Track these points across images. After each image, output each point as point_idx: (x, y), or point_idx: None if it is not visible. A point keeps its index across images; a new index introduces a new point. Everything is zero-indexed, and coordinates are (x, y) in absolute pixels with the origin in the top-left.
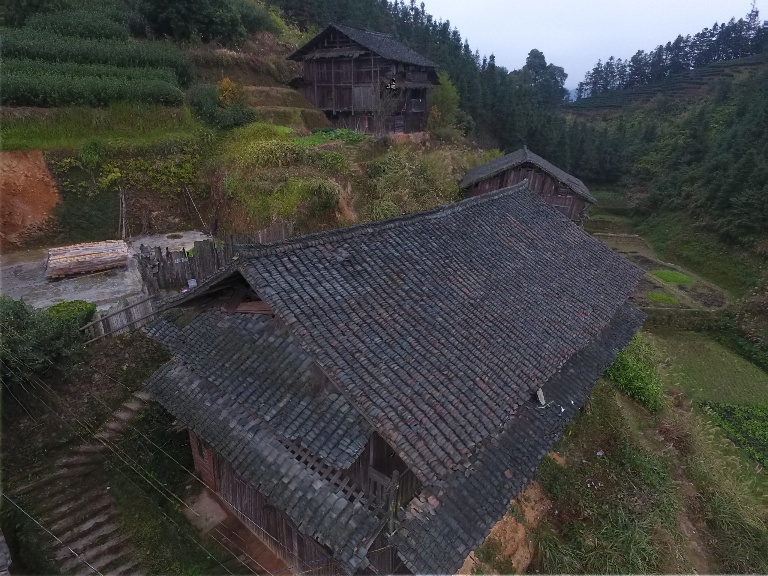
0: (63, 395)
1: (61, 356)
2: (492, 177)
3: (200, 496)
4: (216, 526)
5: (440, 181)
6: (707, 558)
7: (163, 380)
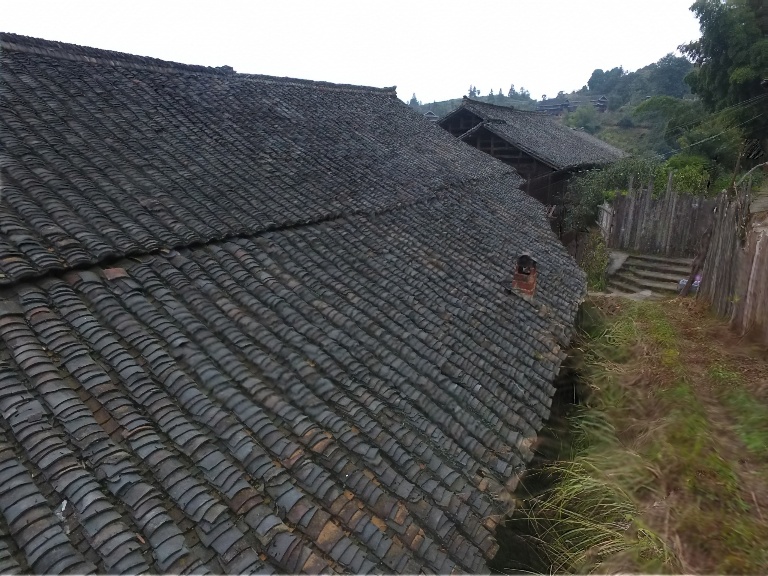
0: None
1: None
2: None
3: None
4: None
5: None
6: None
7: None
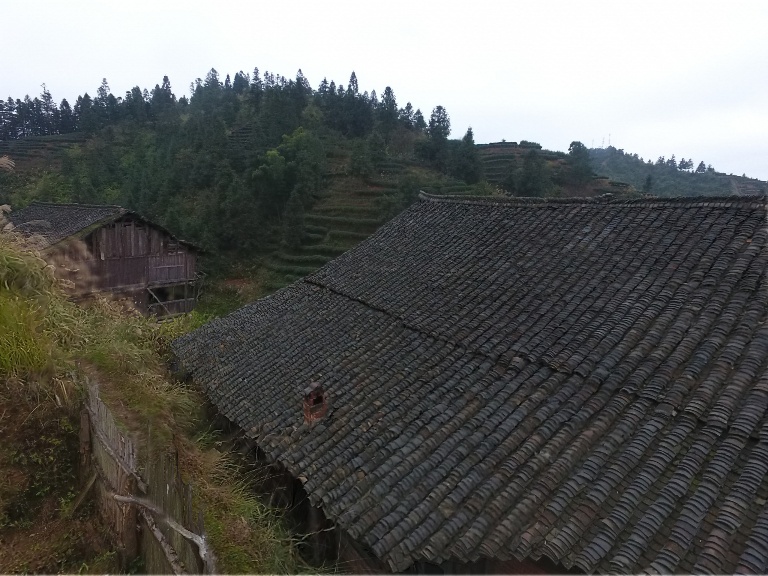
0: None
1: None
2: None
3: None
4: None
5: None
6: None
7: None
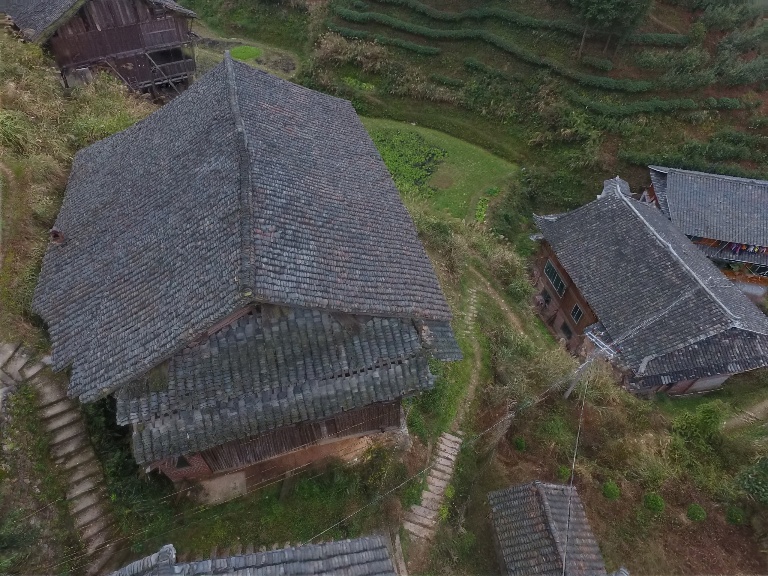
0: (25, 566)
1: (6, 540)
2: (69, 17)
3: (205, 487)
4: (247, 483)
5: (6, 44)
6: (429, 253)
7: (157, 443)
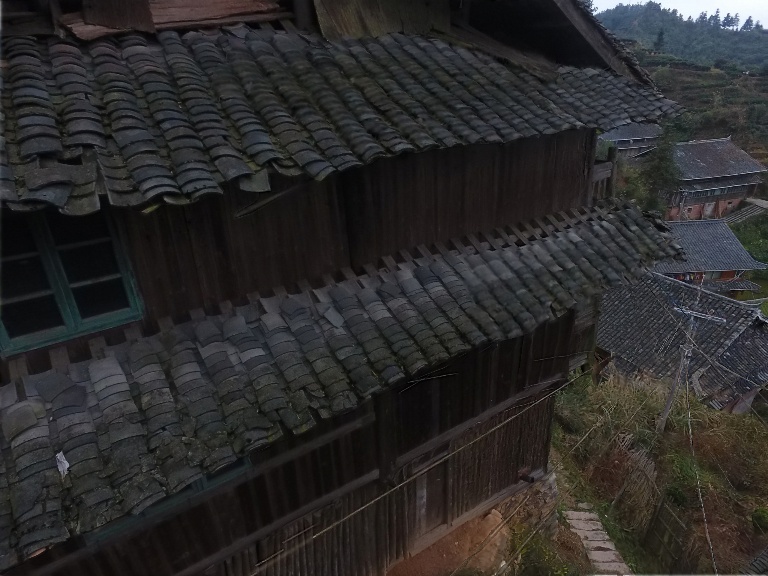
0: None
1: None
2: None
3: None
4: None
5: None
6: None
7: None
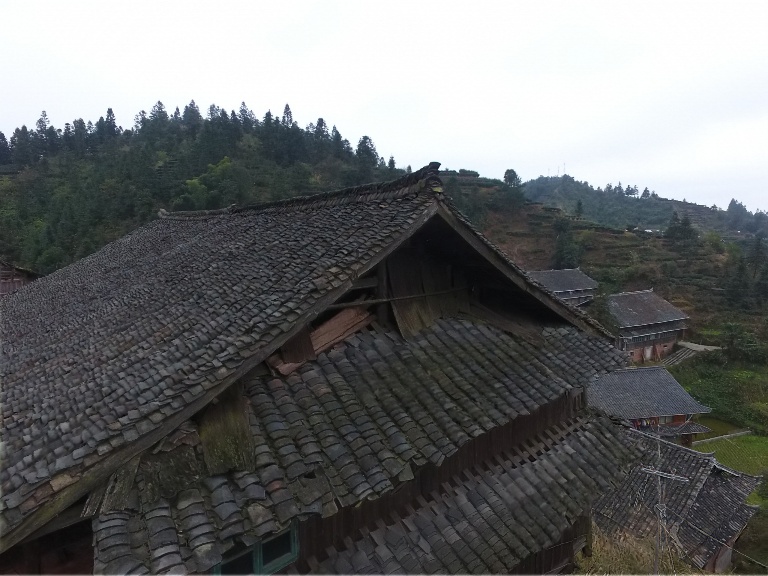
0: None
1: None
2: None
3: None
4: None
5: None
6: None
7: None
